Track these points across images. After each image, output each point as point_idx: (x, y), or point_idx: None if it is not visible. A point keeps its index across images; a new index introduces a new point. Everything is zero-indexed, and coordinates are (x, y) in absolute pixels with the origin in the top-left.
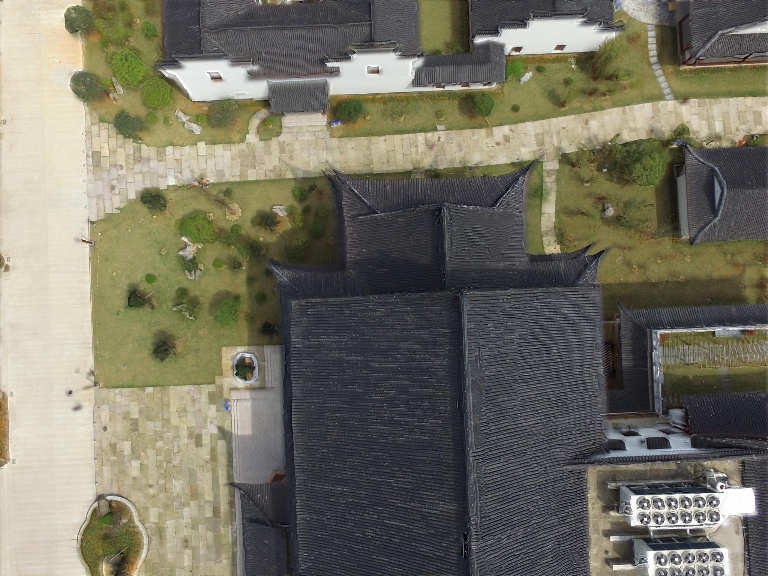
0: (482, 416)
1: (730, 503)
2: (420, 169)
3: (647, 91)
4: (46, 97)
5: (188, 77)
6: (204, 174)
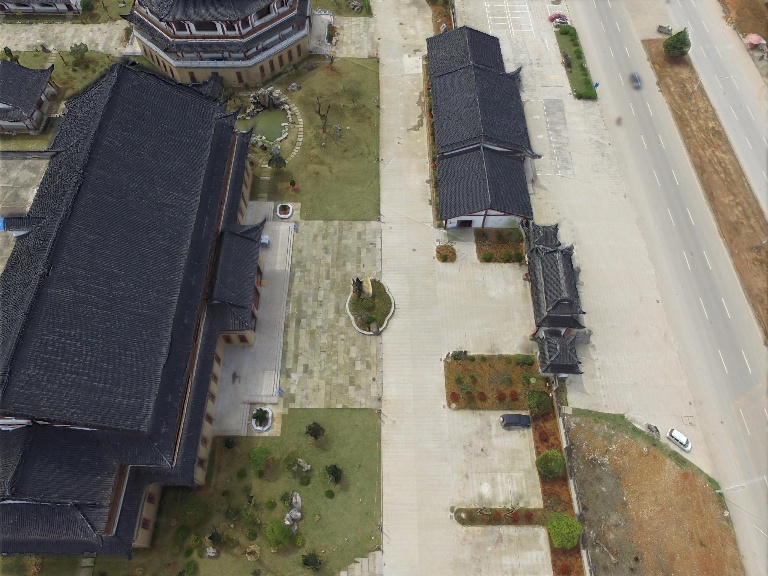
0: (7, 334)
1: None
2: None
3: None
4: None
5: None
6: None
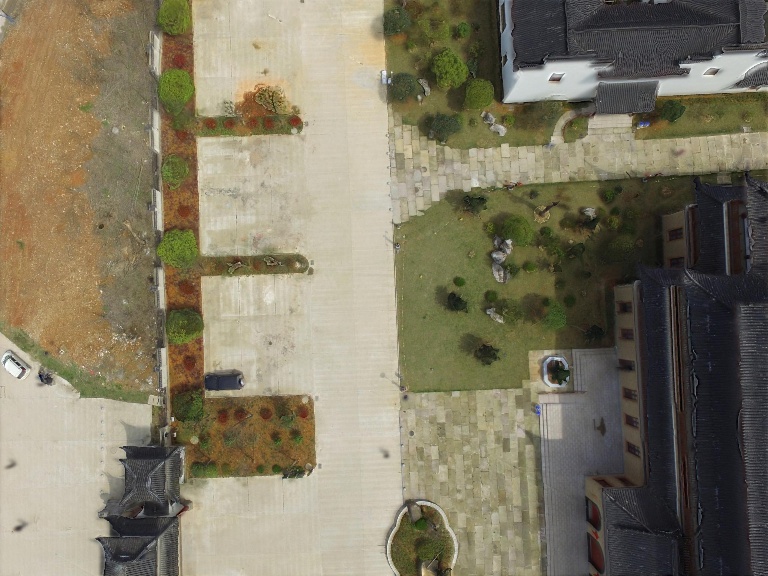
0: None
1: None
2: (726, 171)
3: None
4: (348, 99)
5: (529, 79)
6: (508, 176)
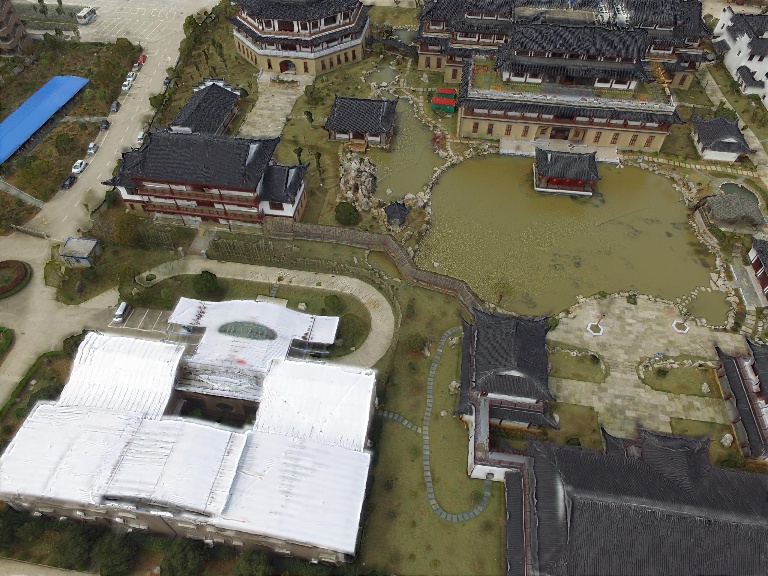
0: None
1: (622, 20)
2: None
3: (761, 135)
4: None
5: None
6: None
